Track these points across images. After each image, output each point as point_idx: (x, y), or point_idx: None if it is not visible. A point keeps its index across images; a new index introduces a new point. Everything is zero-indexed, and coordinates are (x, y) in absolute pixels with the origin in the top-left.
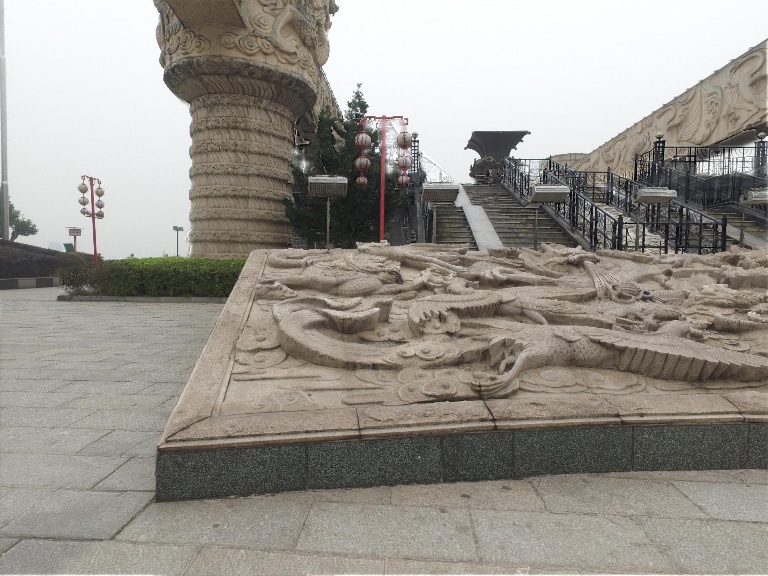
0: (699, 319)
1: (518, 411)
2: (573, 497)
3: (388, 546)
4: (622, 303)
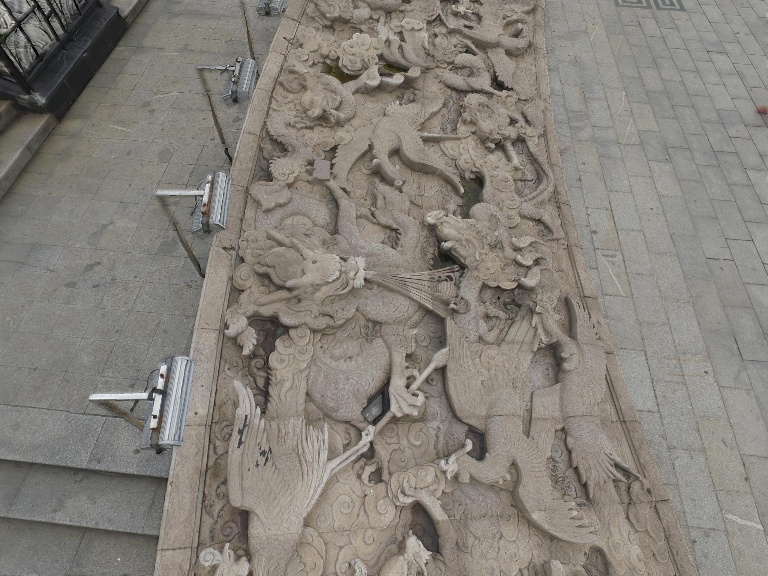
0: (499, 280)
1: (661, 483)
2: (660, 467)
3: (733, 574)
4: (469, 311)
